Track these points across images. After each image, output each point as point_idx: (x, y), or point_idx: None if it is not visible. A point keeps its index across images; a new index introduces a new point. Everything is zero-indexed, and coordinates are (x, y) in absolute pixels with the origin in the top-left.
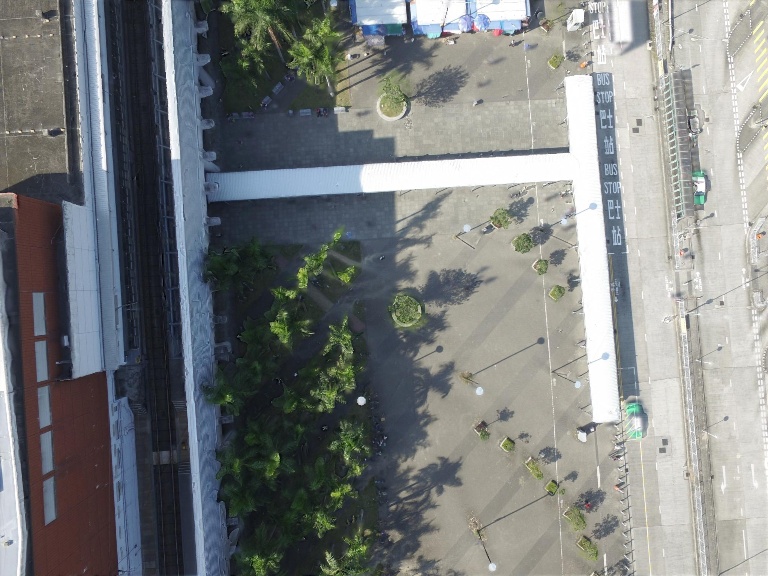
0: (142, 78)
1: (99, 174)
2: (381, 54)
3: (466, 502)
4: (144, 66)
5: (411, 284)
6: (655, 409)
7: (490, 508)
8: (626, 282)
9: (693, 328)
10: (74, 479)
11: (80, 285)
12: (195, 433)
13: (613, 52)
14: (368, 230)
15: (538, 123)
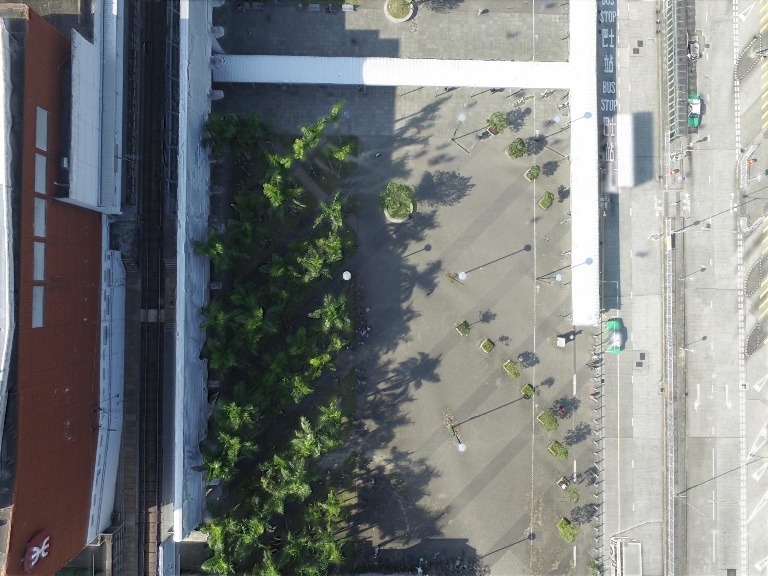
0: None
1: (109, 18)
2: None
3: (443, 398)
4: None
5: (405, 182)
6: (635, 324)
7: (466, 406)
8: (616, 198)
9: (678, 247)
10: (63, 300)
11: (83, 116)
12: (183, 282)
13: None
14: (367, 127)
15: (541, 36)
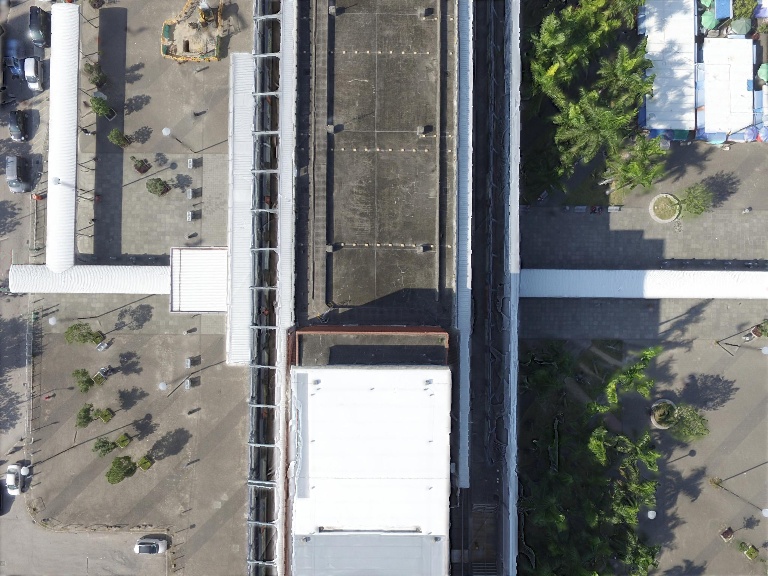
0: None
1: (463, 292)
2: (657, 155)
3: None
4: None
5: (669, 387)
6: None
7: None
8: None
9: None
10: None
11: None
12: (516, 546)
13: None
14: (631, 330)
15: None
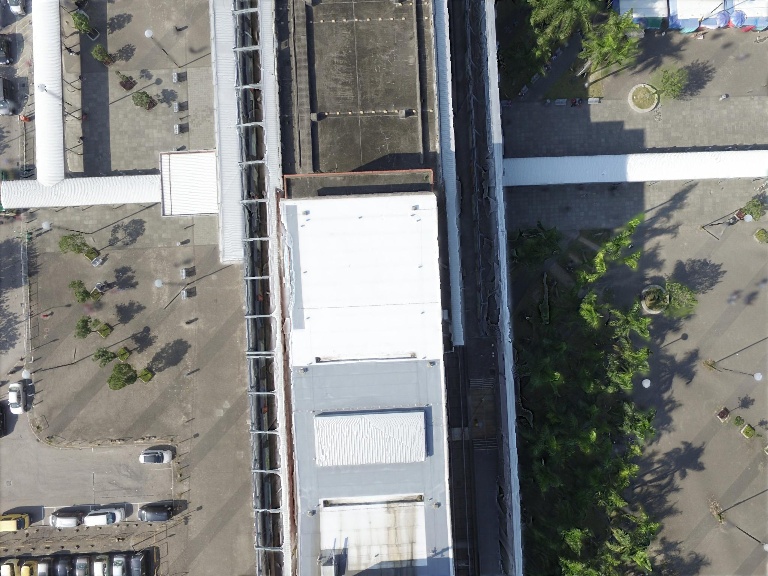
0: None
1: (447, 155)
2: (633, 47)
3: (708, 486)
4: None
5: (658, 273)
6: None
7: (730, 492)
8: None
9: None
10: None
11: None
12: (514, 409)
13: None
14: (618, 219)
15: None
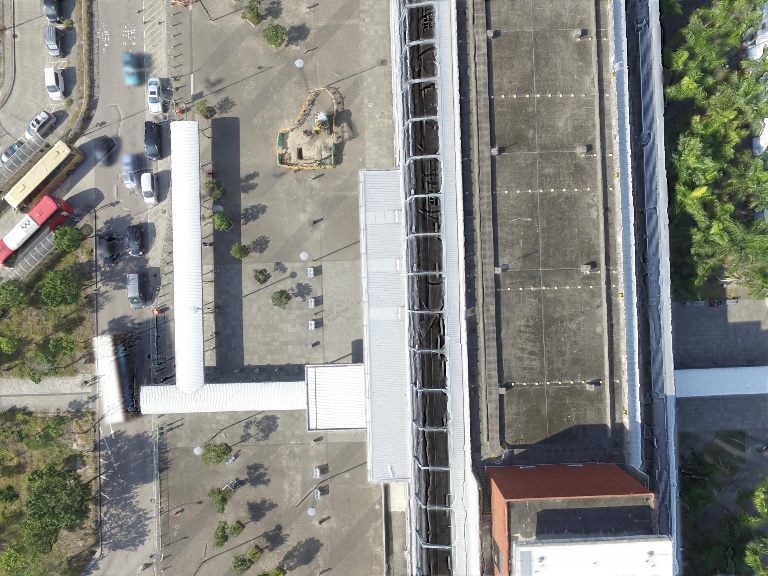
0: None
1: (633, 426)
2: None
3: None
4: None
5: None
6: None
7: None
8: None
9: None
10: None
11: None
12: None
13: None
14: (753, 420)
15: None
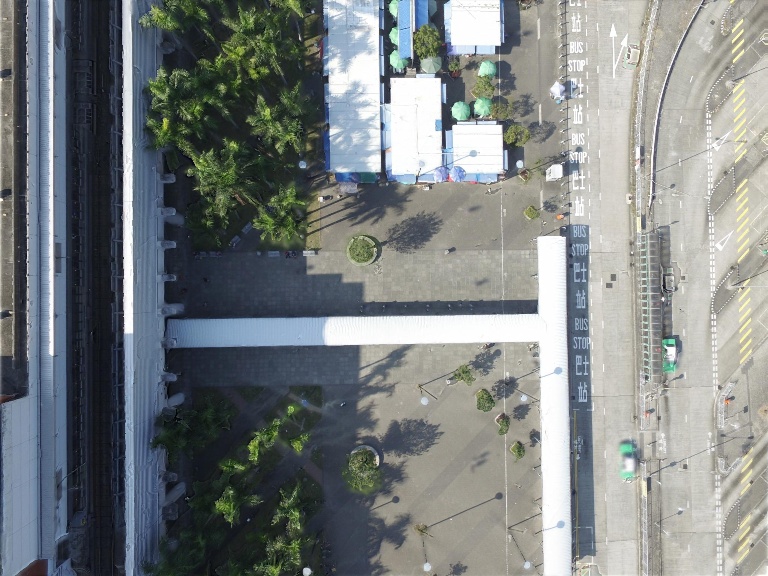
0: (104, 231)
1: (46, 359)
2: (354, 197)
3: None
4: (107, 219)
5: (371, 432)
6: (610, 570)
7: None
8: (589, 440)
9: (654, 490)
10: None
11: (17, 481)
12: None
13: (591, 204)
14: (331, 375)
15: (510, 274)
